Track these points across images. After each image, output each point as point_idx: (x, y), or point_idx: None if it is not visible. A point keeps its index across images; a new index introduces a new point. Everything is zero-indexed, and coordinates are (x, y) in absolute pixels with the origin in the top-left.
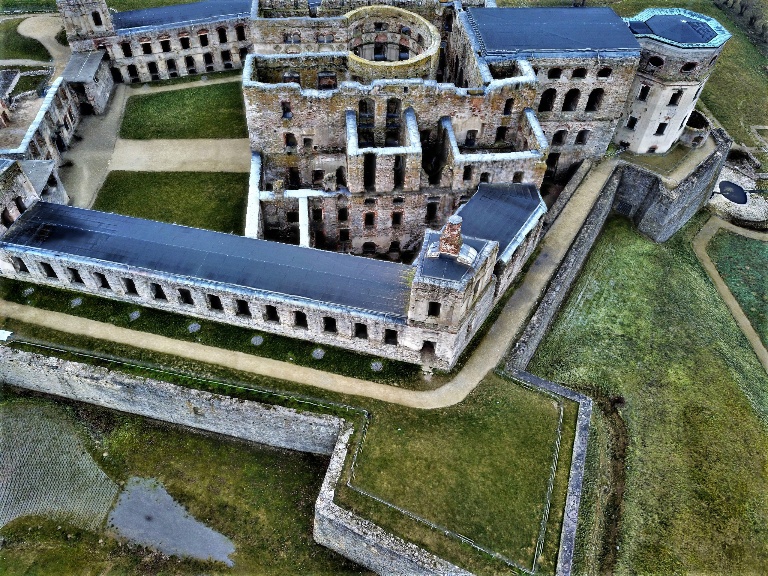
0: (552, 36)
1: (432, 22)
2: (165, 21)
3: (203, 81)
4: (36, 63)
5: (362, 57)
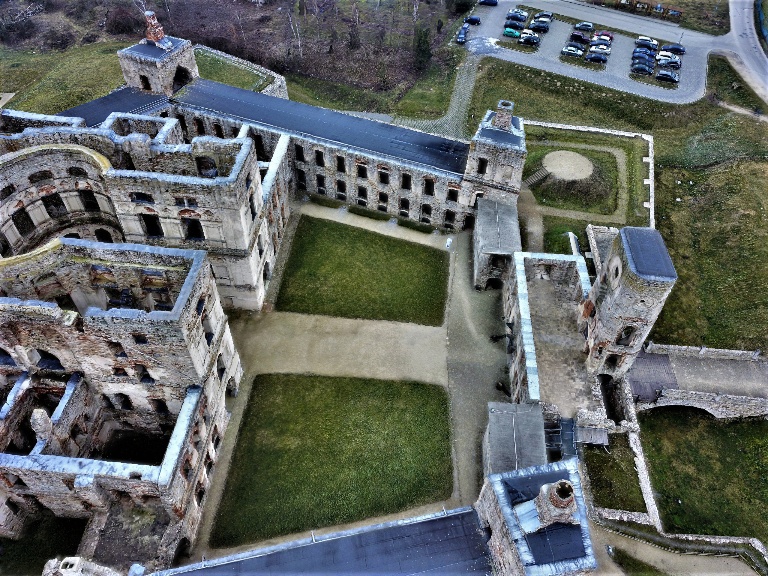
0: None
1: None
2: (372, 541)
3: None
4: (639, 549)
5: None
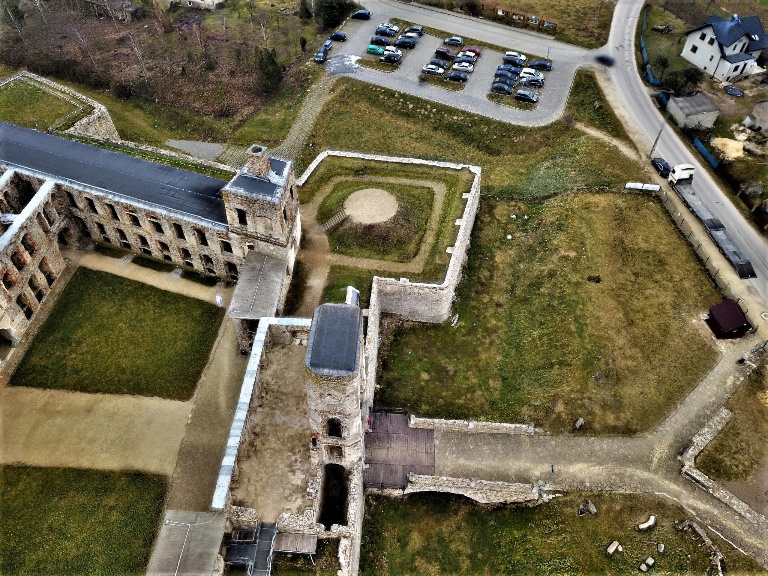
0: None
1: None
2: None
3: None
4: None
5: None
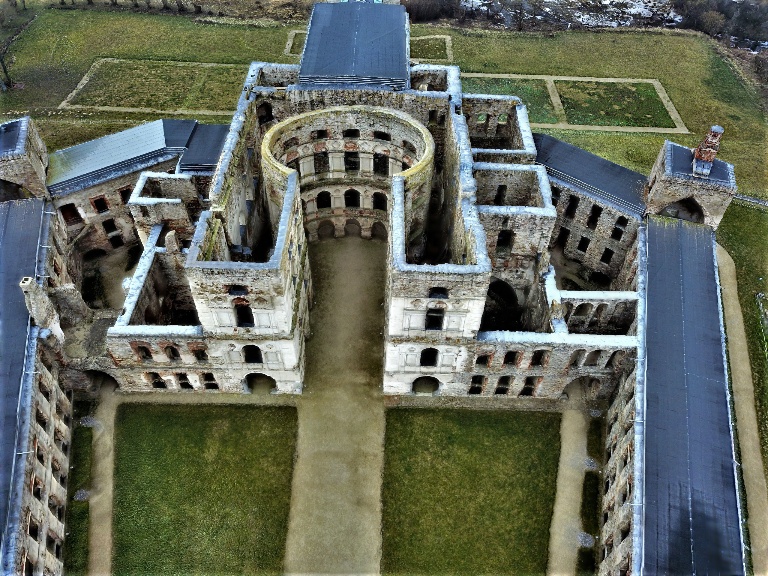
0: (381, 40)
1: (255, 126)
2: None
3: (94, 496)
4: None
5: (279, 211)
